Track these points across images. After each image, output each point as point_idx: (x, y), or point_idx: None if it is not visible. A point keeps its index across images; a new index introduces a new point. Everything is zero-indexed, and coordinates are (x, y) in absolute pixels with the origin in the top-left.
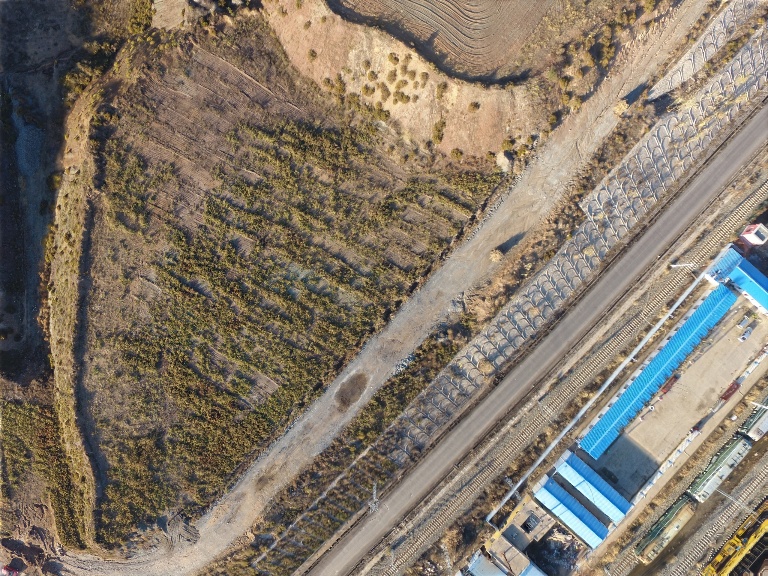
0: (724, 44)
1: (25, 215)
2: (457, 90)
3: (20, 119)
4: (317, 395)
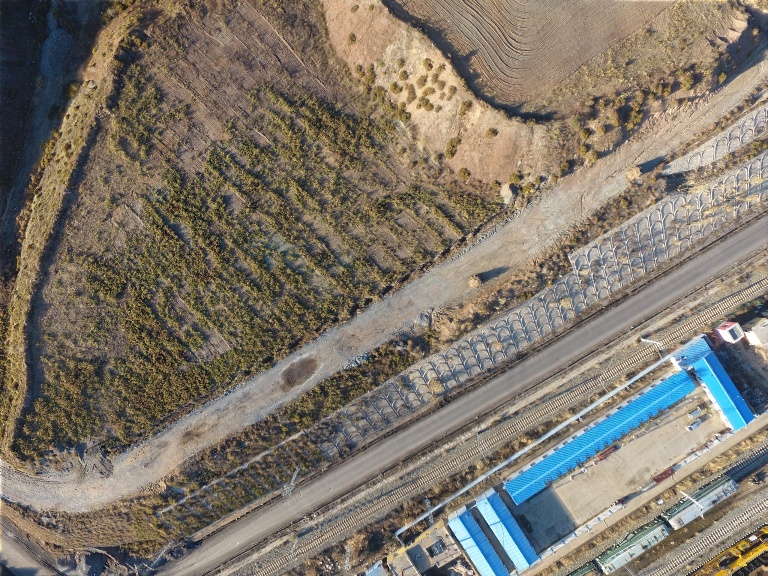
0: (750, 141)
1: (33, 115)
2: (480, 112)
3: (54, 21)
4: (265, 367)
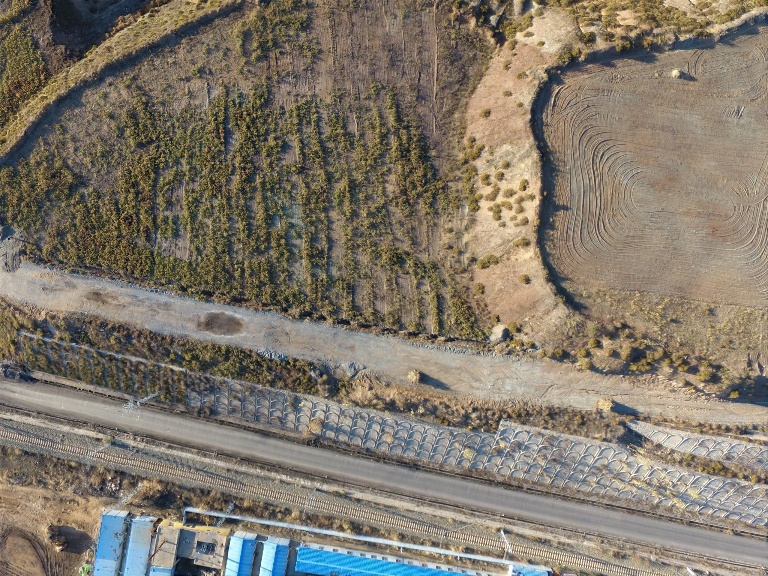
0: (715, 459)
1: None
2: (530, 256)
3: None
4: (199, 297)
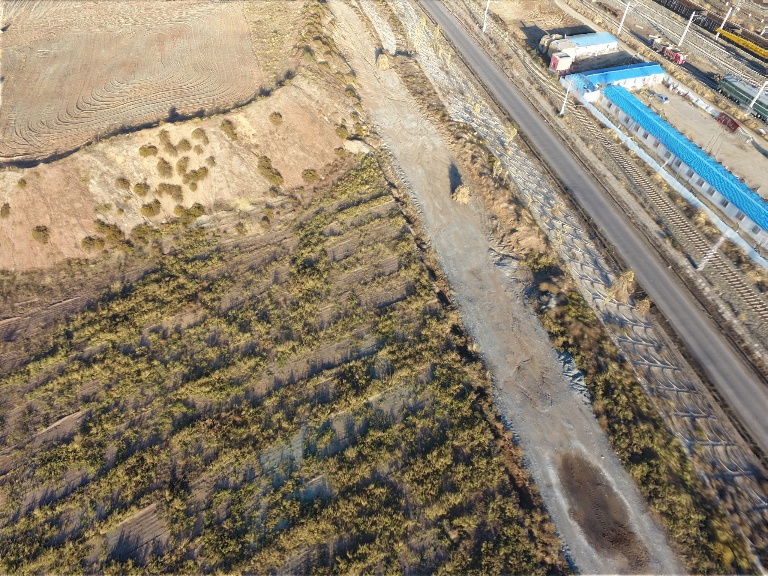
0: (387, 23)
1: None
2: (244, 118)
3: None
4: None
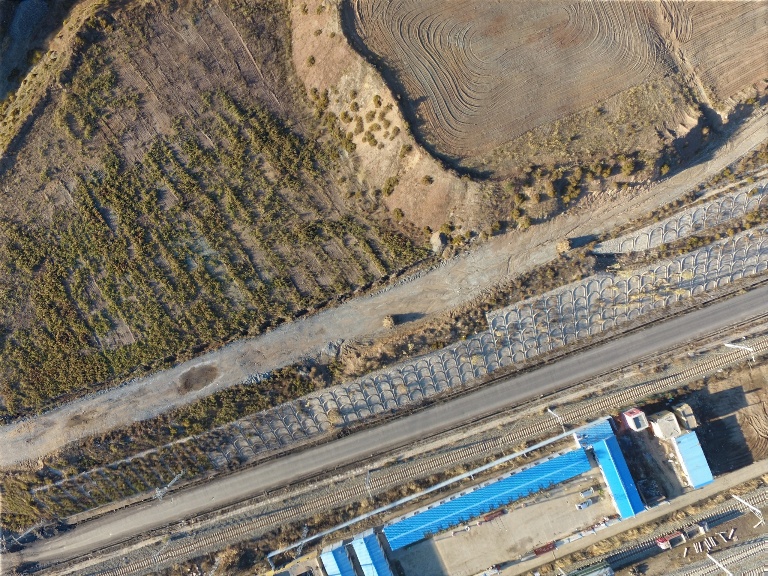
0: (687, 236)
1: None
2: (419, 158)
3: None
4: (165, 367)
